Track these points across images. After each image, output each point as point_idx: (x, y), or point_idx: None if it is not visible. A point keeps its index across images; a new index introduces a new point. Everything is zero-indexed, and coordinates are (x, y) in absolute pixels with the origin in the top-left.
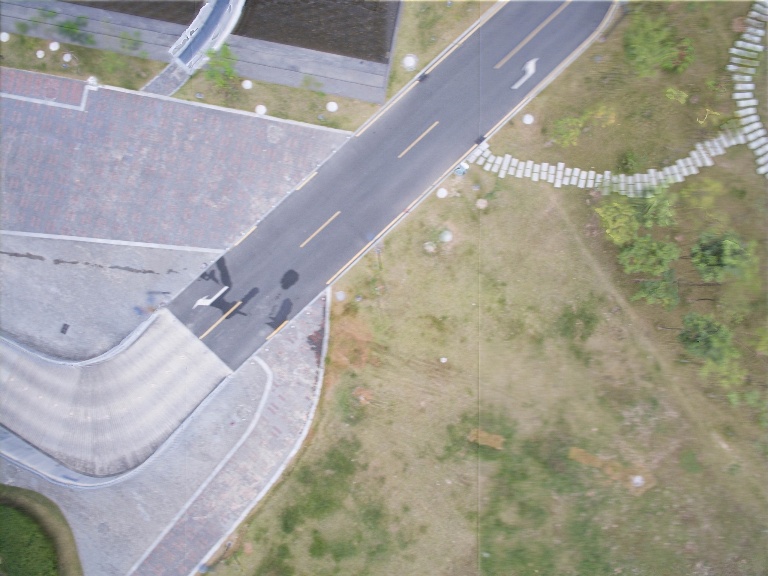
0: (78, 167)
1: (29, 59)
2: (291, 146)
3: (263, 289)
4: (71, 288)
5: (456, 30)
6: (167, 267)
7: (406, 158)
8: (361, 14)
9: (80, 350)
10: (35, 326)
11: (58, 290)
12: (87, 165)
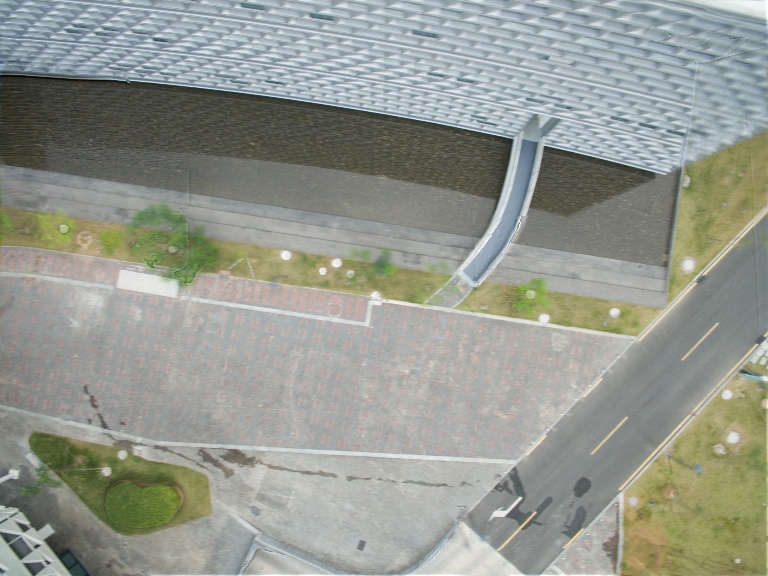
0: (366, 383)
1: (312, 277)
2: (576, 353)
3: (556, 498)
4: (365, 504)
5: (732, 231)
6: (460, 480)
7: (689, 360)
8: (636, 217)
9: (378, 566)
10: (331, 544)
11: (352, 507)
12: (375, 380)
